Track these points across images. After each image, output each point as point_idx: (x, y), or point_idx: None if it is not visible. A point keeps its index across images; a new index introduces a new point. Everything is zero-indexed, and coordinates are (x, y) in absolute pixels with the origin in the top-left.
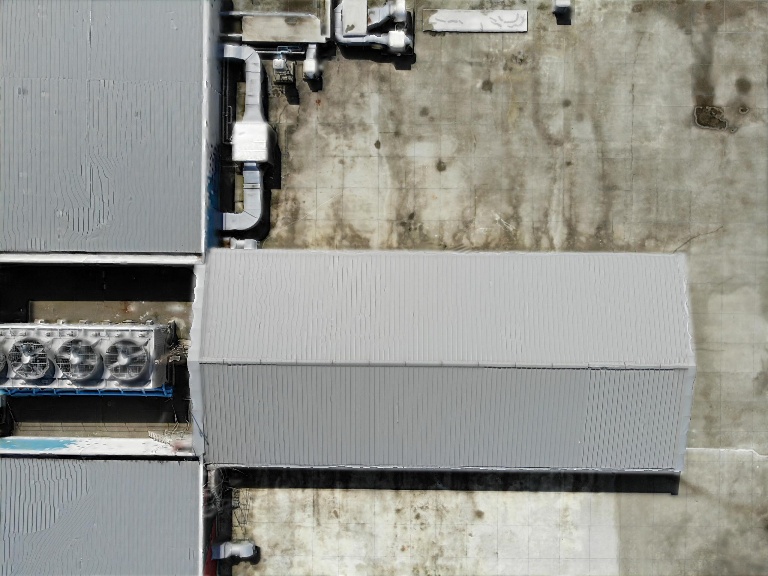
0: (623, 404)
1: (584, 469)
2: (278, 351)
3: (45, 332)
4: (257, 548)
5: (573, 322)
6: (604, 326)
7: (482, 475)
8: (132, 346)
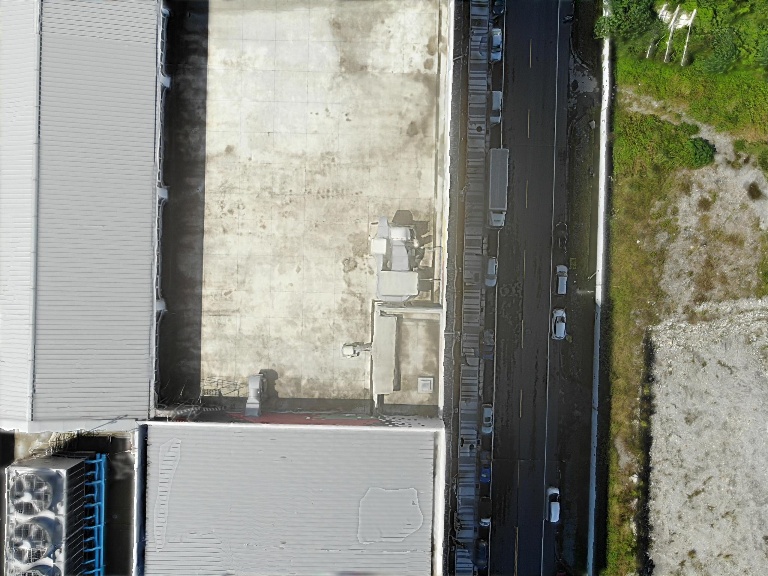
0: (82, 1)
1: (185, 45)
2: (23, 343)
3: (8, 575)
4: (262, 373)
5: (1, 50)
6: (4, 19)
7: (190, 147)
8: (16, 488)
